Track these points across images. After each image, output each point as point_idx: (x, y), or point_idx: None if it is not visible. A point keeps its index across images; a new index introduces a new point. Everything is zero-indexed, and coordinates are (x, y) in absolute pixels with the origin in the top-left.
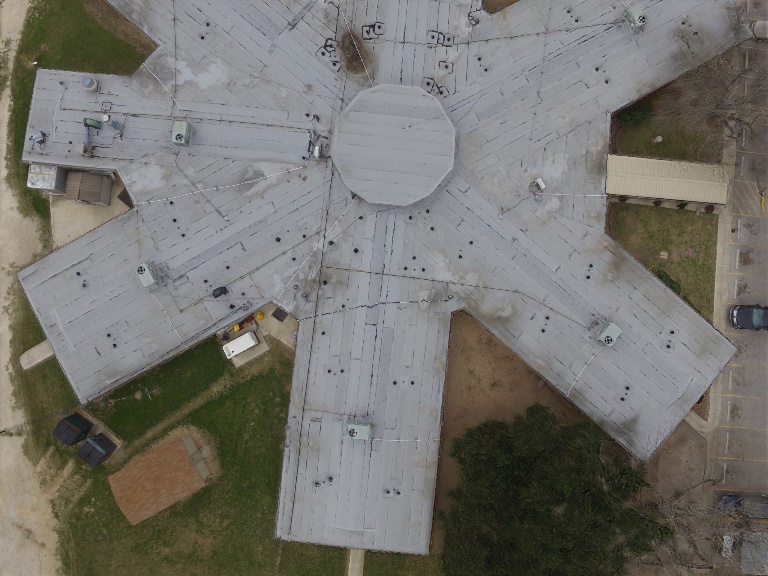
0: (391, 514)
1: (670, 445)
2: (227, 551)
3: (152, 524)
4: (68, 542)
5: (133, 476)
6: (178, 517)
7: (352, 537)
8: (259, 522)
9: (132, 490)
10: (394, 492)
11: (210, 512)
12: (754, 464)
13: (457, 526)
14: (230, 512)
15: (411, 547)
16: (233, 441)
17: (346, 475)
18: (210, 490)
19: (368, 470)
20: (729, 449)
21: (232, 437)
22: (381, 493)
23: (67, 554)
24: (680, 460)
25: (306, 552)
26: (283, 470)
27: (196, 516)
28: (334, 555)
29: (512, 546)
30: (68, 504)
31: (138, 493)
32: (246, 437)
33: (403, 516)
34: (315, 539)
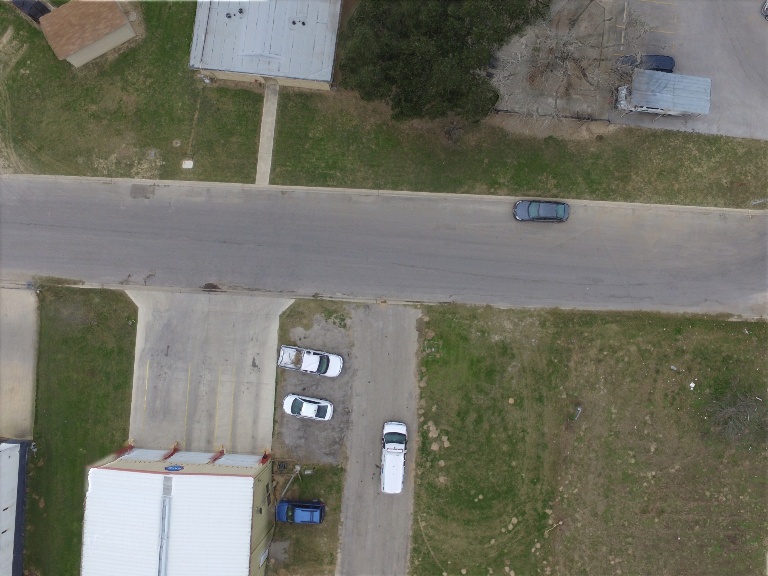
0: (296, 44)
1: (569, 12)
2: (149, 108)
3: (81, 83)
4: (5, 103)
5: (61, 14)
6: (105, 76)
7: (259, 64)
8: (179, 79)
9: (59, 25)
10: (299, 23)
11: (134, 70)
12: (652, 33)
13: (351, 27)
14: (153, 72)
15: (314, 74)
16: (157, 7)
17: (255, 7)
18: (135, 51)
19: (275, 1)
20: (627, 18)
21: (157, 3)
22: (287, 24)
23: (3, 114)
24: (579, 26)
25: (222, 106)
26: (197, 6)
27: (121, 74)
28: (248, 109)
29: (400, 35)
30: (6, 67)
31: (64, 27)
32: (169, 3)
33: (307, 46)
34: (225, 66)
